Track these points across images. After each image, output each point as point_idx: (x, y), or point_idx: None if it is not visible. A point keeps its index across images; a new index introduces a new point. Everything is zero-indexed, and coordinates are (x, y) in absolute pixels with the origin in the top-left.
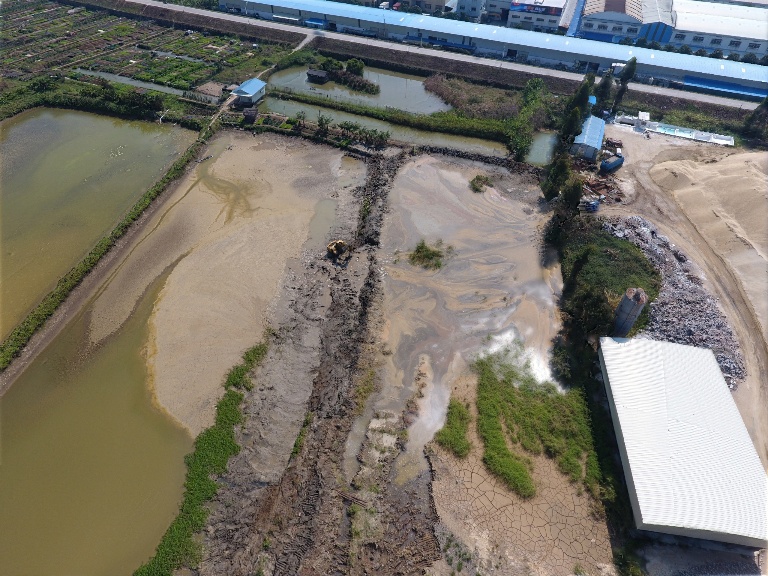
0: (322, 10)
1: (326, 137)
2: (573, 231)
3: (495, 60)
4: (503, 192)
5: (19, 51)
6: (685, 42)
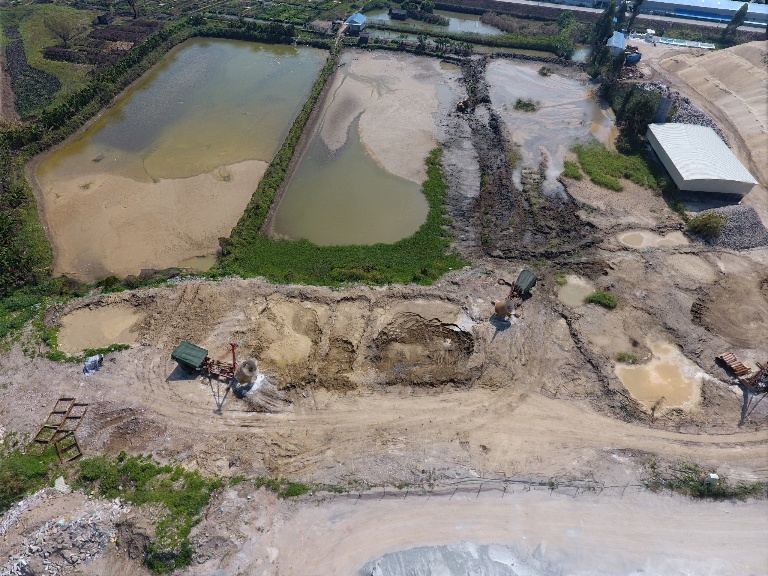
0: None
1: (424, 50)
2: (617, 89)
3: (532, 1)
4: (562, 76)
5: (153, 1)
6: None
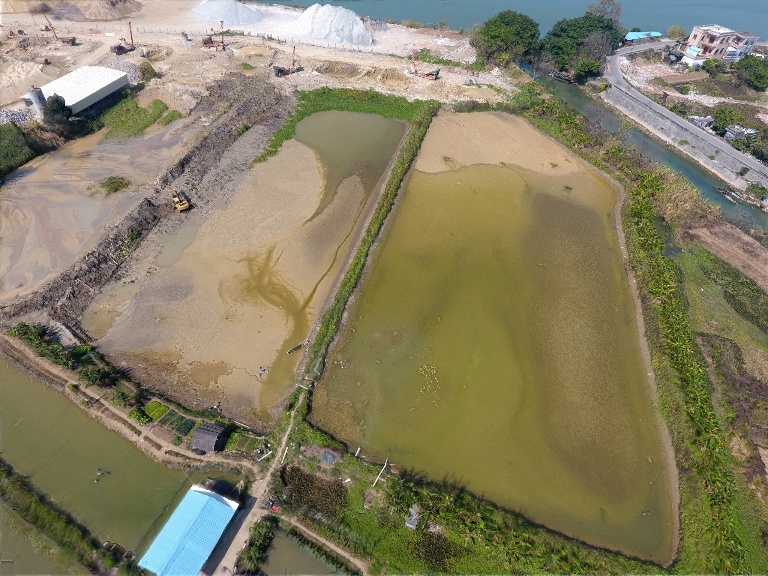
0: None
1: None
2: None
3: None
4: None
5: None
6: None
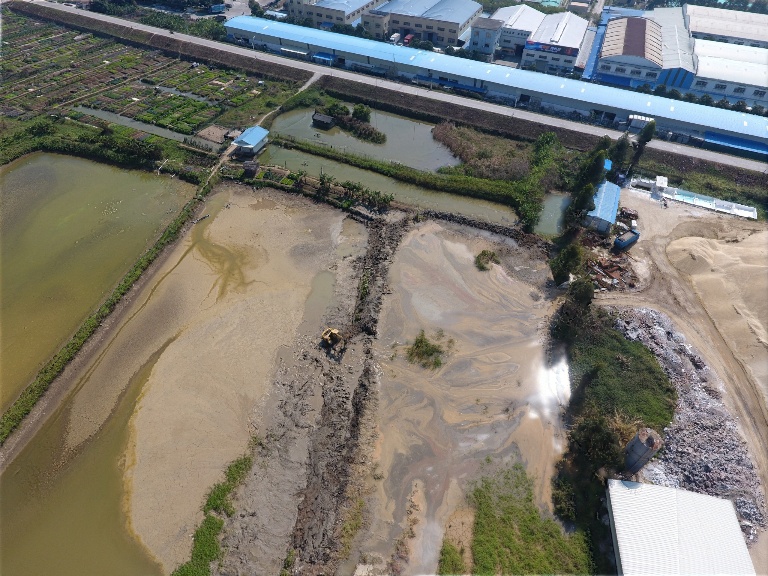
0: (331, 45)
1: (328, 196)
2: (583, 327)
3: (507, 107)
4: (510, 271)
5: (21, 85)
6: (706, 89)
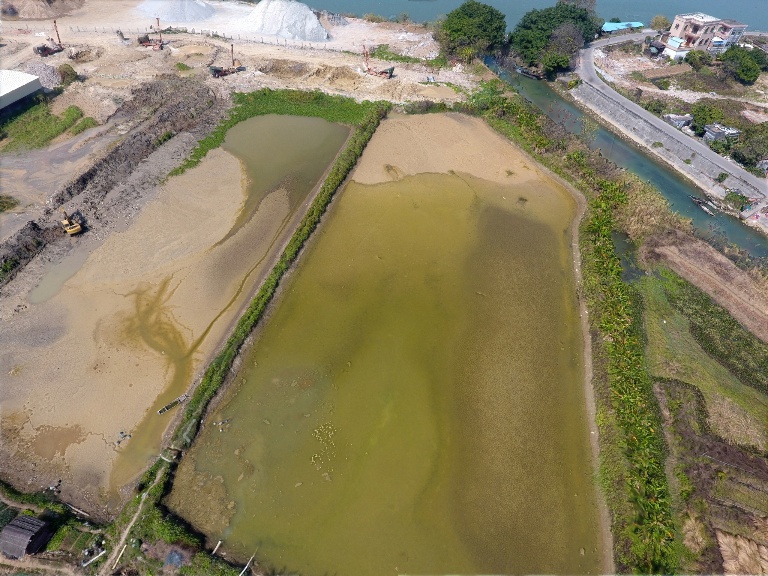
0: None
1: None
2: None
3: None
4: None
5: None
6: None
